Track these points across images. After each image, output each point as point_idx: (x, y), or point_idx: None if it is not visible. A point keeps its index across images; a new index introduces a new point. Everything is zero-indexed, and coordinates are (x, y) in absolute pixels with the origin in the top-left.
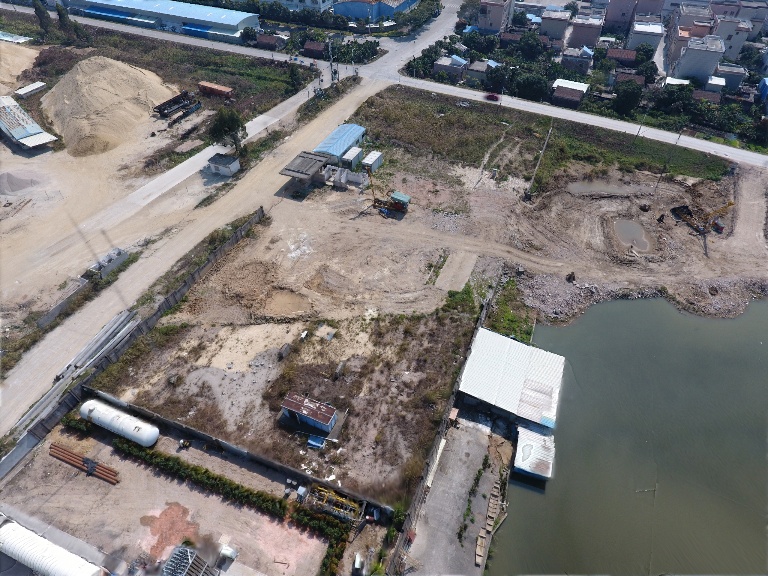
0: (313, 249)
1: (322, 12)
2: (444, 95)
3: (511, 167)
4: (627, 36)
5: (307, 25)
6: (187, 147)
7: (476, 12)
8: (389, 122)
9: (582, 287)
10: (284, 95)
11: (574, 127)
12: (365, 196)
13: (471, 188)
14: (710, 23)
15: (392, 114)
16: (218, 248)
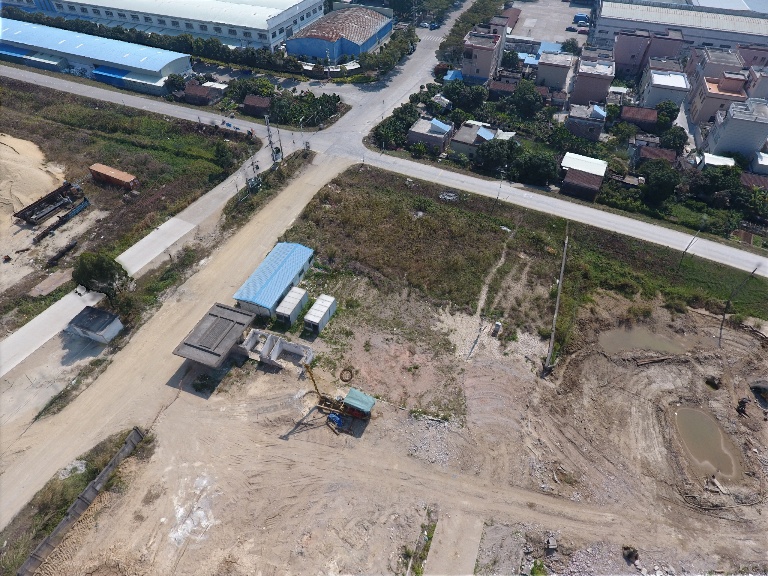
0: (214, 516)
1: (270, 53)
2: (422, 182)
3: (519, 312)
4: (638, 83)
5: (252, 67)
6: (51, 285)
7: (459, 53)
8: (348, 231)
9: (651, 575)
10: (207, 184)
11: (598, 236)
12: (307, 384)
13: (465, 357)
14: (744, 75)
15: (352, 217)
16: (41, 543)
